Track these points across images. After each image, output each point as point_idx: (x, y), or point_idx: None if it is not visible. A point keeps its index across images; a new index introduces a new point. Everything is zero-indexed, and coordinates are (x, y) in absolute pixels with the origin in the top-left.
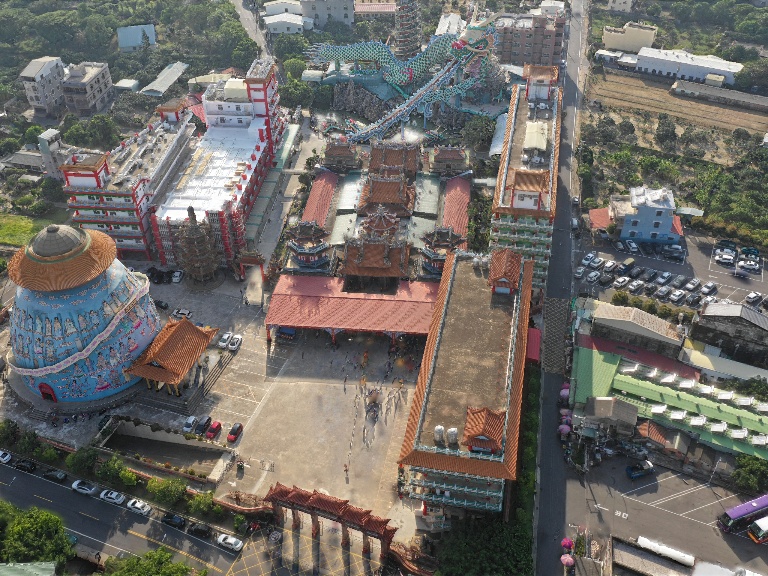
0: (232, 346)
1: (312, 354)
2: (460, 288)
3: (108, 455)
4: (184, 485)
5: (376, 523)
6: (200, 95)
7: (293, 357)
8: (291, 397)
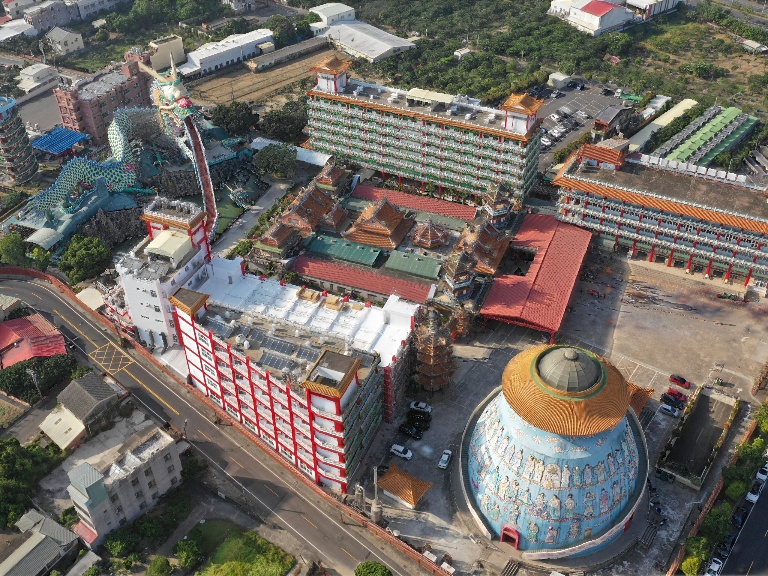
0: None
1: (576, 325)
2: None
3: (709, 475)
4: (763, 408)
5: None
6: None
7: (579, 337)
8: (634, 344)
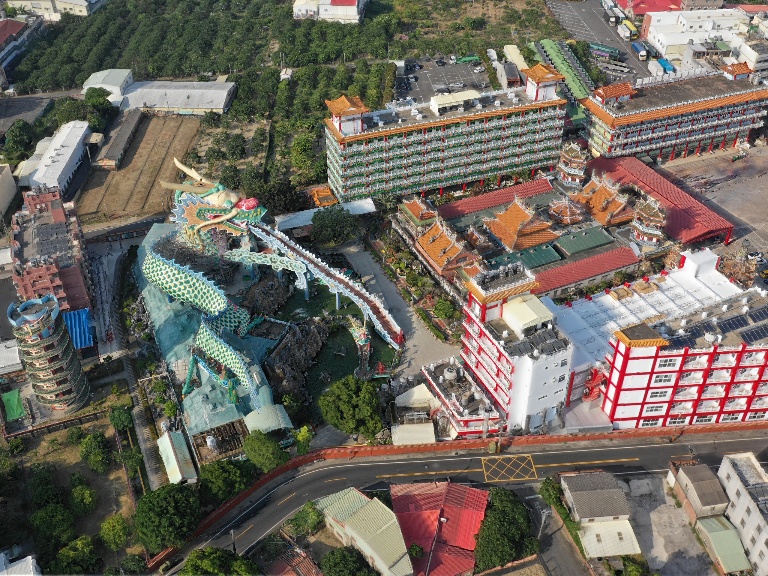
0: (760, 253)
1: None
2: (645, 108)
3: None
4: None
5: None
6: (422, 546)
7: None
8: (751, 214)
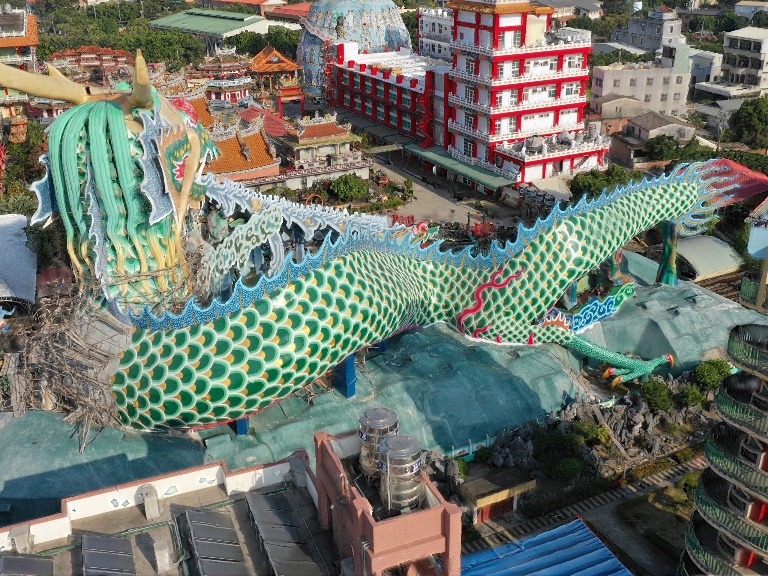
0: None
1: None
2: None
3: None
4: None
5: None
6: None
7: None
8: None
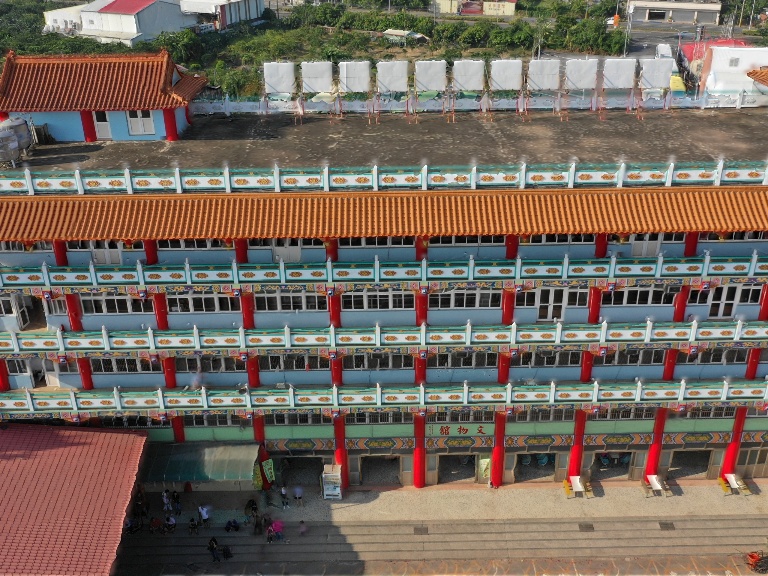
0: None
1: None
2: None
3: None
4: None
5: None
6: None
7: None
8: None
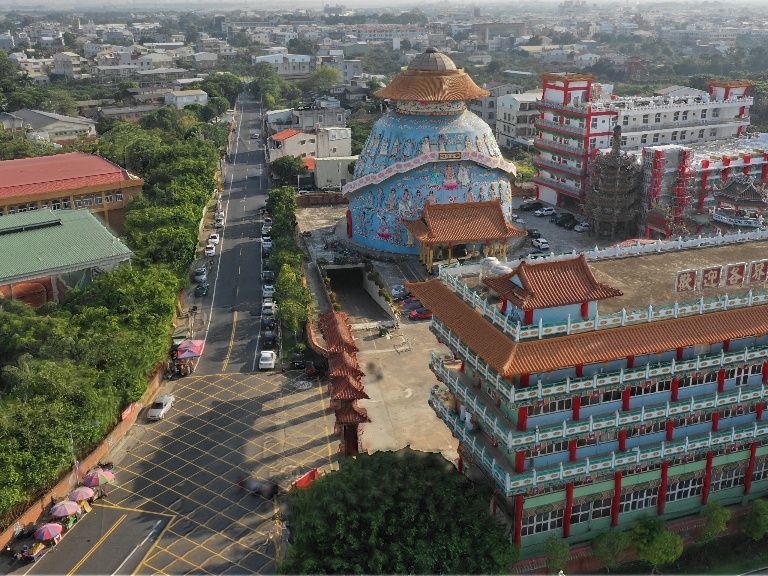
0: None
1: None
2: None
3: None
4: None
5: (345, 384)
6: None
7: None
8: None
